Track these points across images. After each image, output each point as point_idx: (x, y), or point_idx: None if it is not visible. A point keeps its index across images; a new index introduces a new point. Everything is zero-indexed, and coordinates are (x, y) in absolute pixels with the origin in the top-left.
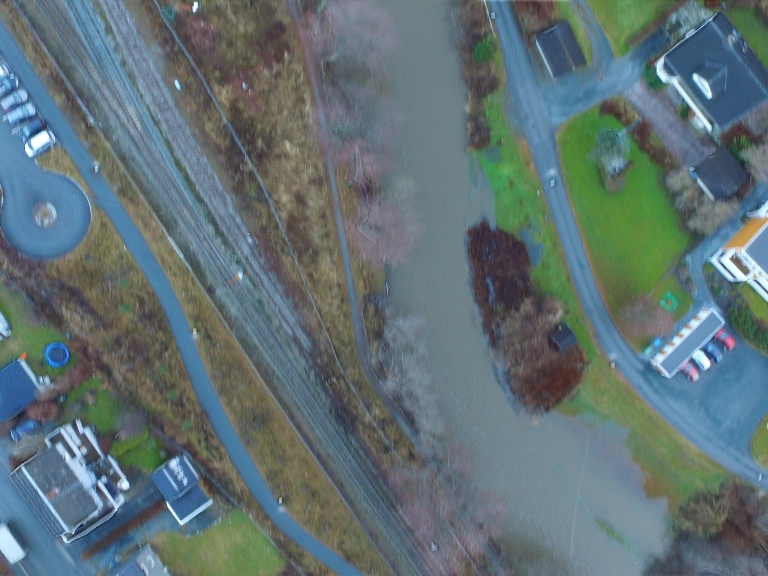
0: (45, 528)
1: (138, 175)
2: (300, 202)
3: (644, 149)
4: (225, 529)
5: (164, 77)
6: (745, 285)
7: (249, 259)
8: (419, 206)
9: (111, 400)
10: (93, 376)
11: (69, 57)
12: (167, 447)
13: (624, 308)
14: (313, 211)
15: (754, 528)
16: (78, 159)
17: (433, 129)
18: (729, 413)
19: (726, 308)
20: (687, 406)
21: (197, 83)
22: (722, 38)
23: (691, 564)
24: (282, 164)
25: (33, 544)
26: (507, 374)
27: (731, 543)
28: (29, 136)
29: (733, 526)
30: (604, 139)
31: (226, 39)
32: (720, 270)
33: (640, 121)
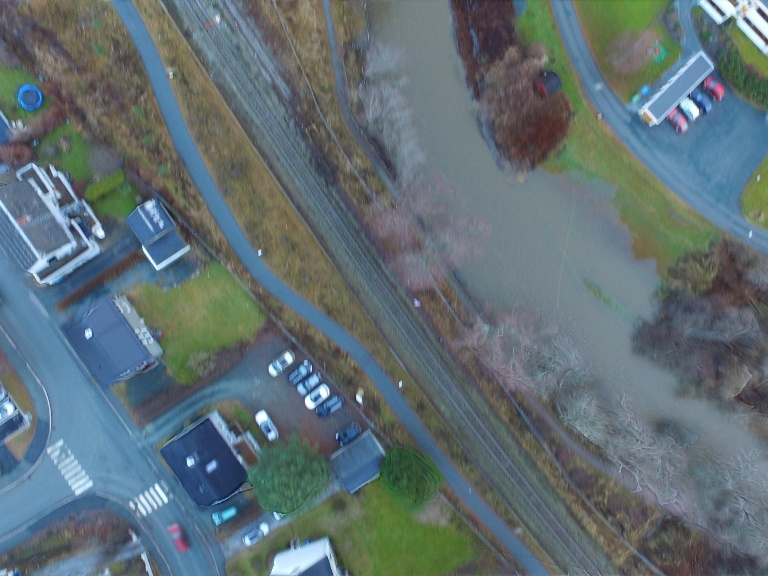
0: (17, 260)
1: None
2: None
3: None
4: (203, 283)
5: None
6: (734, 27)
7: (227, 3)
8: None
9: (86, 147)
10: (67, 122)
11: None
12: (143, 192)
13: (611, 56)
14: None
15: (744, 284)
16: None
17: None
18: (719, 168)
19: (715, 56)
20: (676, 160)
21: None
22: None
23: (680, 320)
24: None
25: (6, 296)
26: (491, 128)
27: (721, 297)
28: None
29: (723, 284)
30: None
31: None
32: (709, 12)
33: None
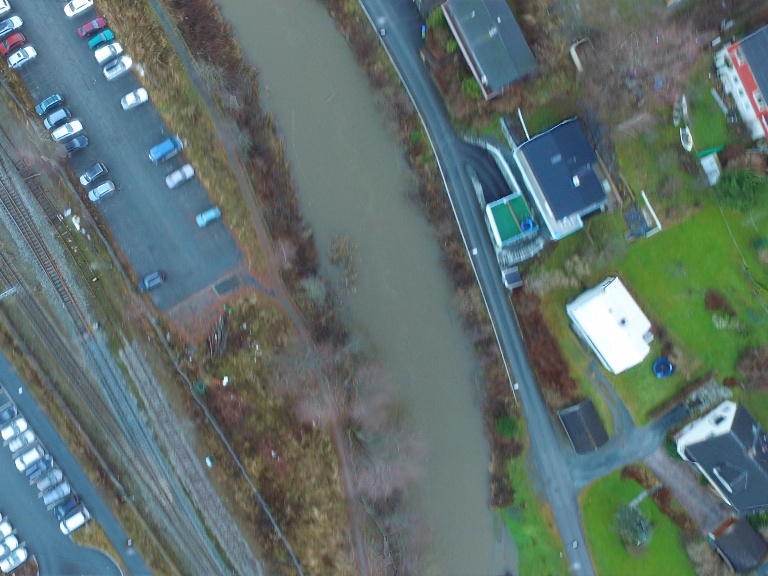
0: None
1: (170, 545)
2: (328, 564)
3: (664, 512)
4: None
5: (195, 449)
6: None
7: None
8: (444, 566)
9: None
10: None
11: (102, 432)
12: None
13: None
14: (341, 574)
15: None
16: (112, 533)
17: (458, 491)
18: None
19: None
20: None
21: (227, 456)
22: (743, 449)
23: None
24: (310, 529)
25: None
26: None
27: None
28: (64, 516)
29: None
30: (627, 524)
31: (256, 413)
32: None
33: (661, 487)
